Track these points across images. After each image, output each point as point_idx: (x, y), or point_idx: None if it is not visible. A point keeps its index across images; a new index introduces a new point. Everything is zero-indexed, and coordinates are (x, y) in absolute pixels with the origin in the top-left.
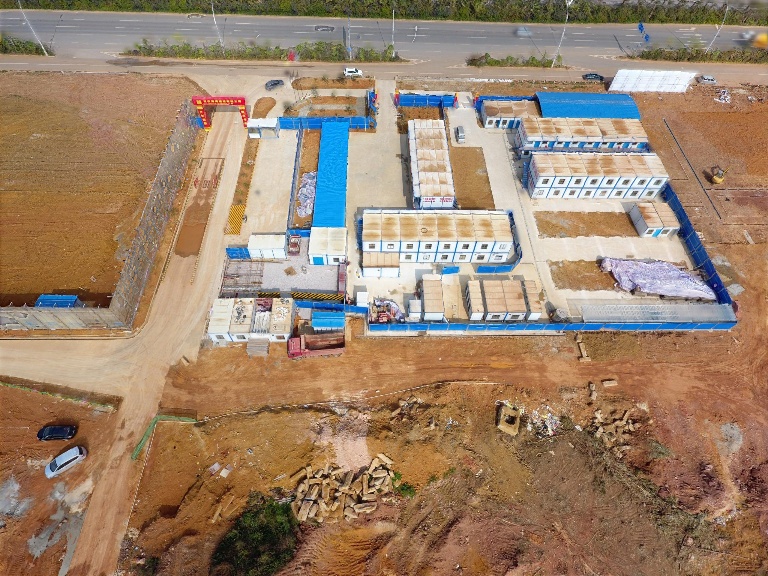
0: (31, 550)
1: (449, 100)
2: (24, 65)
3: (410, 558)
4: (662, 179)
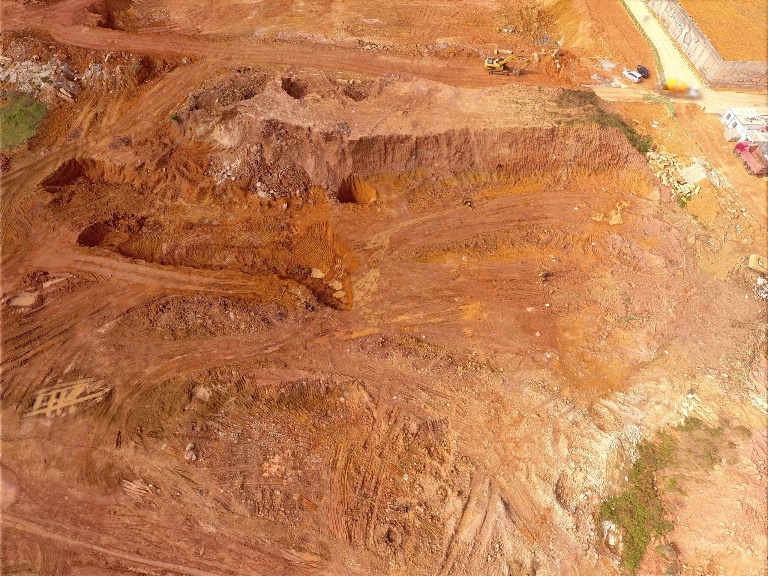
0: (592, 75)
1: None
2: None
3: (642, 209)
4: None
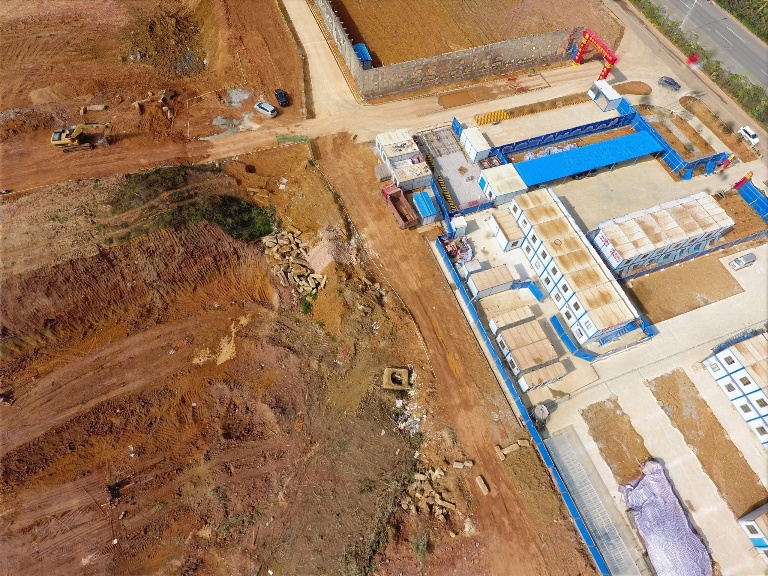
0: (215, 119)
1: None
2: None
3: (260, 327)
4: None
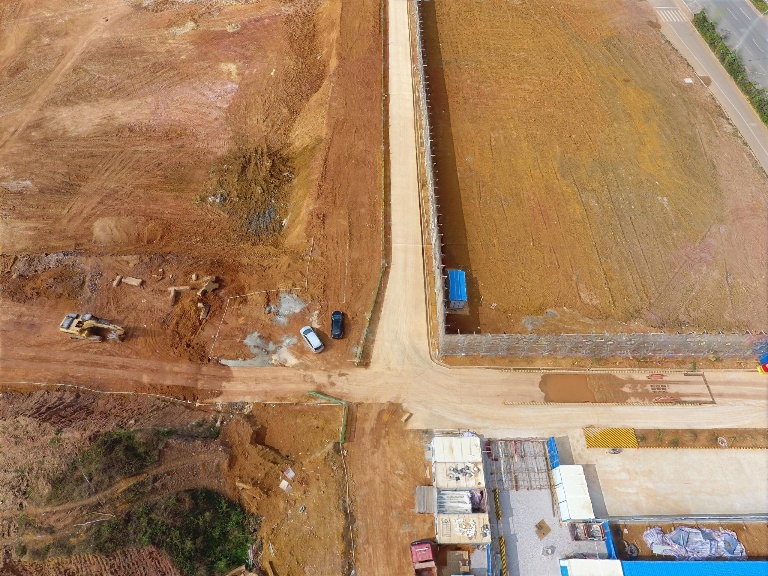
0: (249, 336)
1: None
2: (765, 155)
3: None
4: None
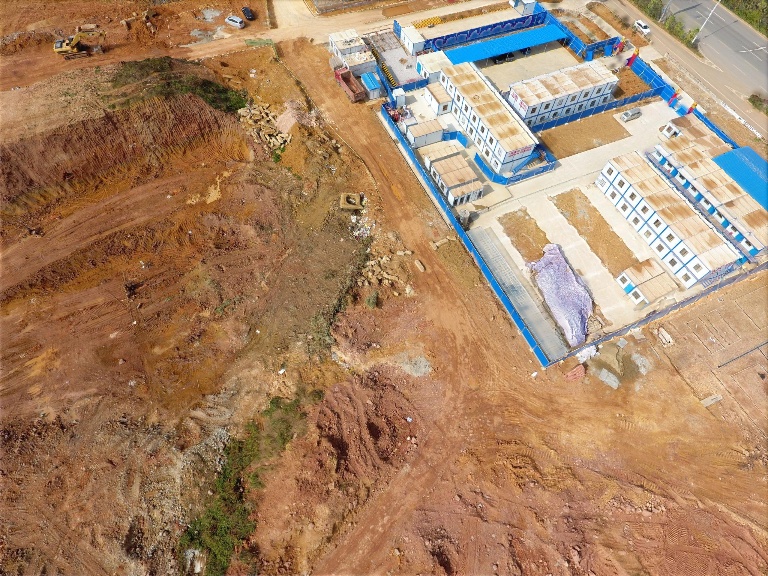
0: (192, 32)
1: (669, 93)
2: None
3: (240, 176)
4: (703, 267)
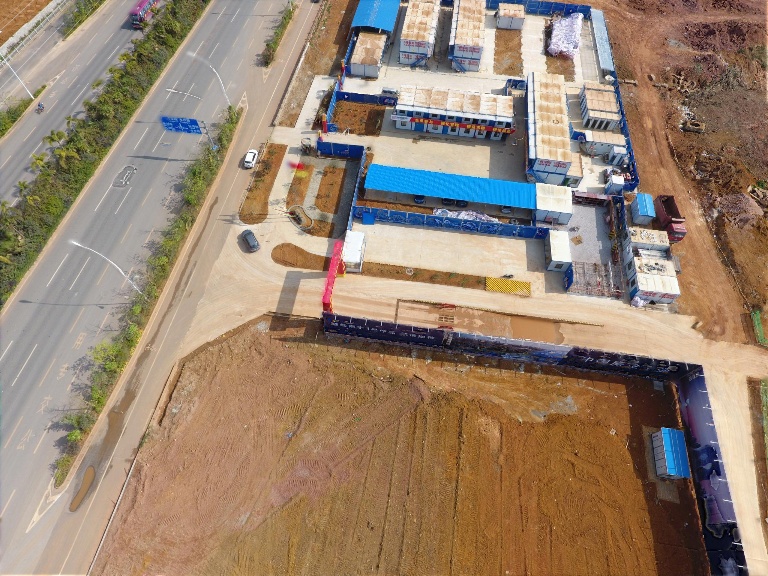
0: None
1: (337, 87)
2: None
3: None
4: None
